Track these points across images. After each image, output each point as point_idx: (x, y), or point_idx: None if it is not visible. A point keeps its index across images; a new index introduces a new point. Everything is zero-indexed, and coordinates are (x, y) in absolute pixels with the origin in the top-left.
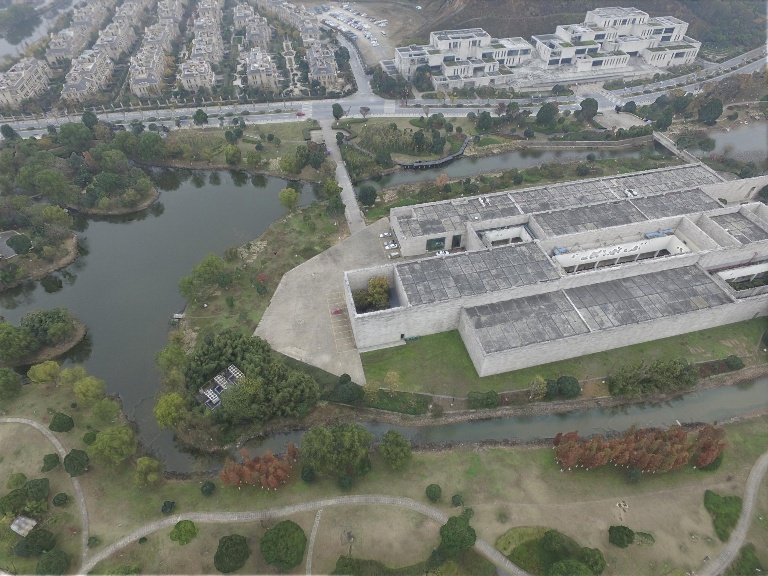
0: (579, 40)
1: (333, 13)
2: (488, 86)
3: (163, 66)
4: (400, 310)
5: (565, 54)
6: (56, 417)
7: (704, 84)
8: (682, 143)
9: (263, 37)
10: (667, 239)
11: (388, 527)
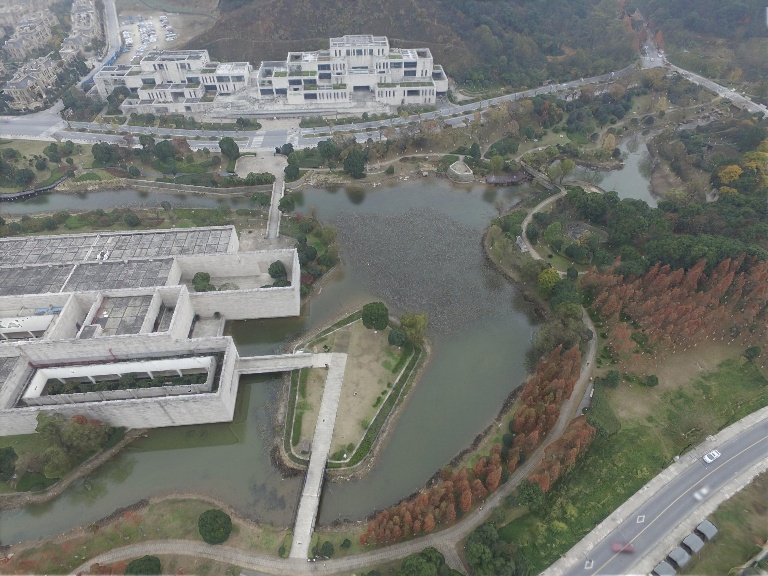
0: (301, 69)
1: (143, 24)
2: (176, 113)
3: None
4: None
5: (277, 84)
6: None
7: (386, 130)
8: (251, 199)
9: (19, 46)
10: (51, 318)
11: None
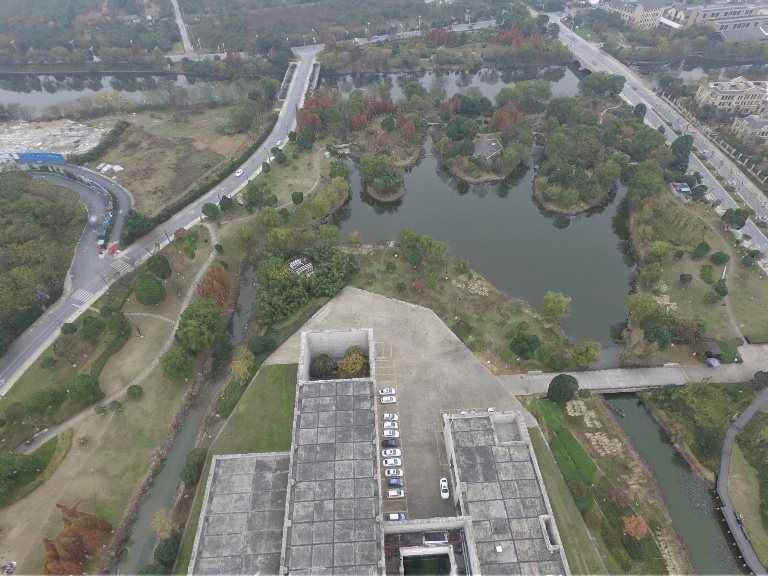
0: None
1: None
2: None
3: None
4: (299, 372)
5: None
6: None
7: None
8: None
9: None
10: None
11: (135, 359)
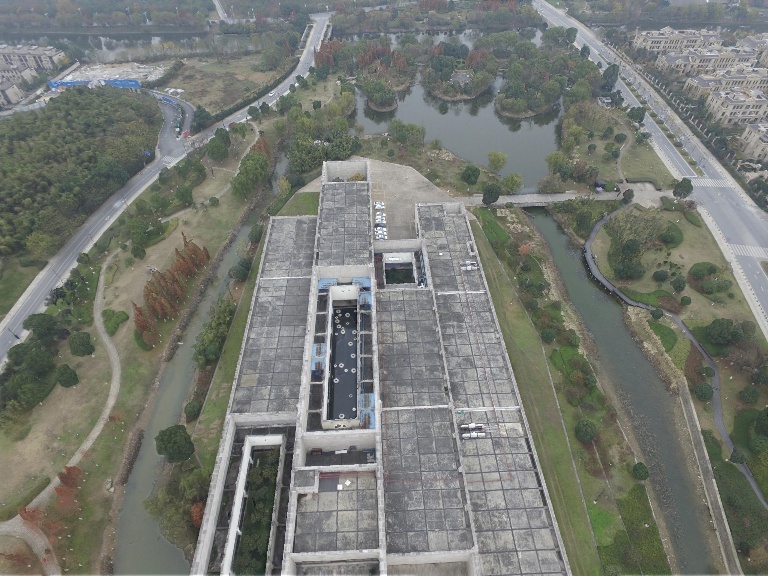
0: None
1: None
2: None
3: (764, 91)
4: None
5: None
6: None
7: None
8: None
9: None
10: None
11: (211, 188)
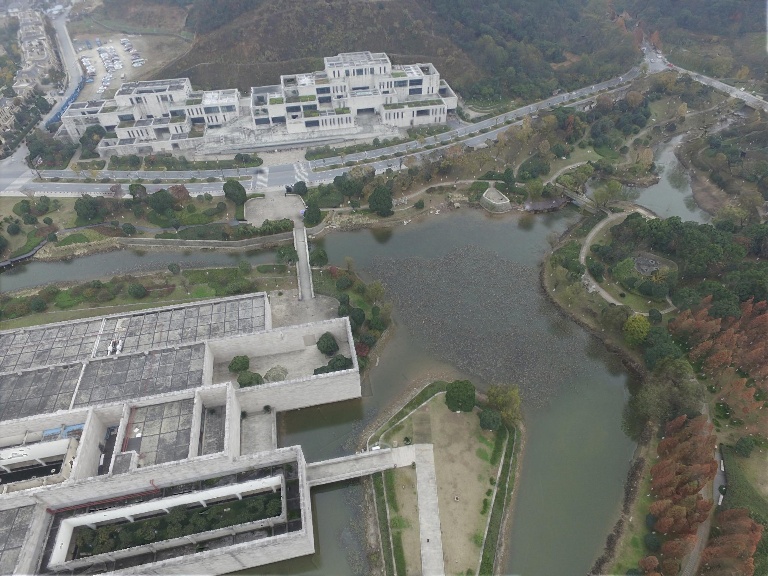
0: (298, 94)
1: (103, 48)
2: (163, 153)
3: None
4: None
5: (273, 112)
6: None
7: (406, 158)
8: (277, 256)
9: None
10: (65, 442)
11: None
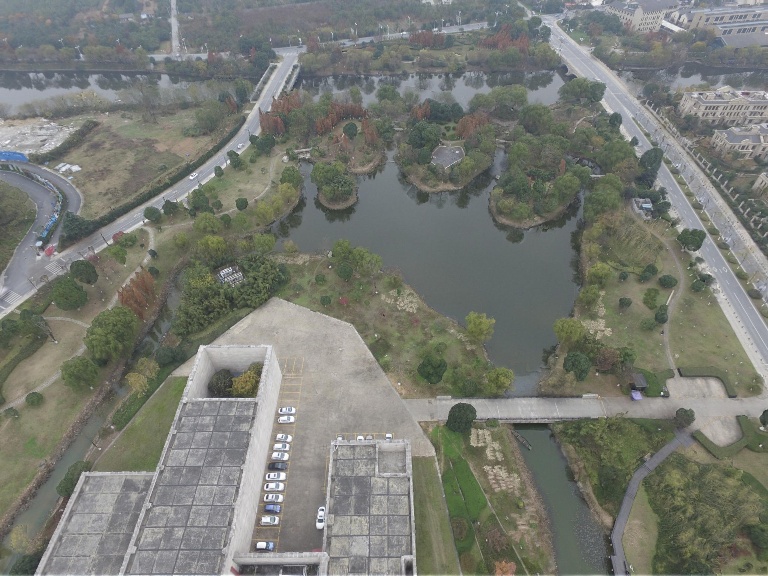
0: None
1: None
2: None
3: None
4: None
5: None
6: (241, 198)
7: None
8: None
9: None
10: None
11: (44, 365)
